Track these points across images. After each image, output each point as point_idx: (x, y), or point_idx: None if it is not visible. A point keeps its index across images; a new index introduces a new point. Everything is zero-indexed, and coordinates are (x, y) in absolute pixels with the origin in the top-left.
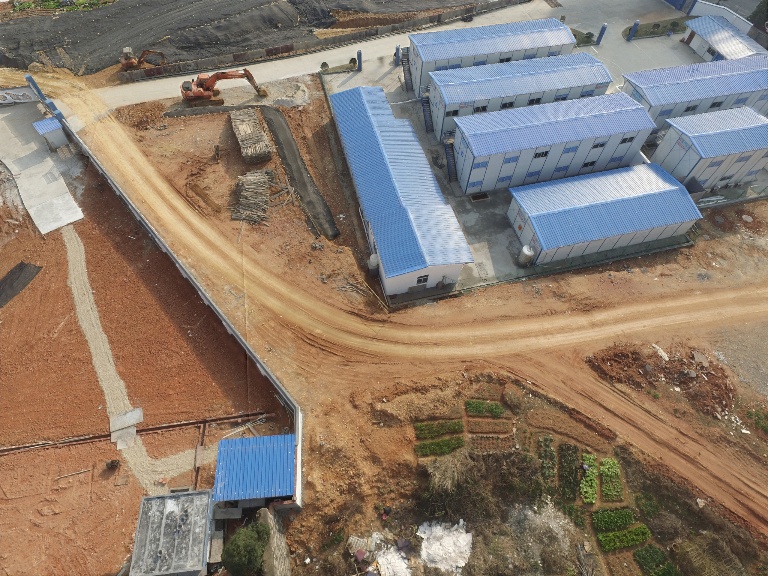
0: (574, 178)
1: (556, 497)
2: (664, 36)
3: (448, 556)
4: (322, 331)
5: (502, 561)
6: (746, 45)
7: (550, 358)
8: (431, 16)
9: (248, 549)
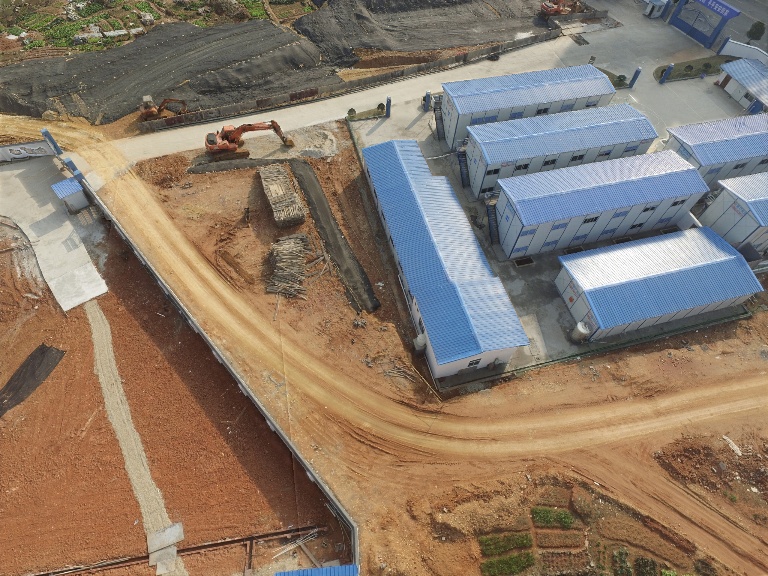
0: (625, 244)
1: None
2: (697, 78)
3: None
4: (371, 425)
5: None
6: None
7: (616, 454)
8: (457, 56)
9: None
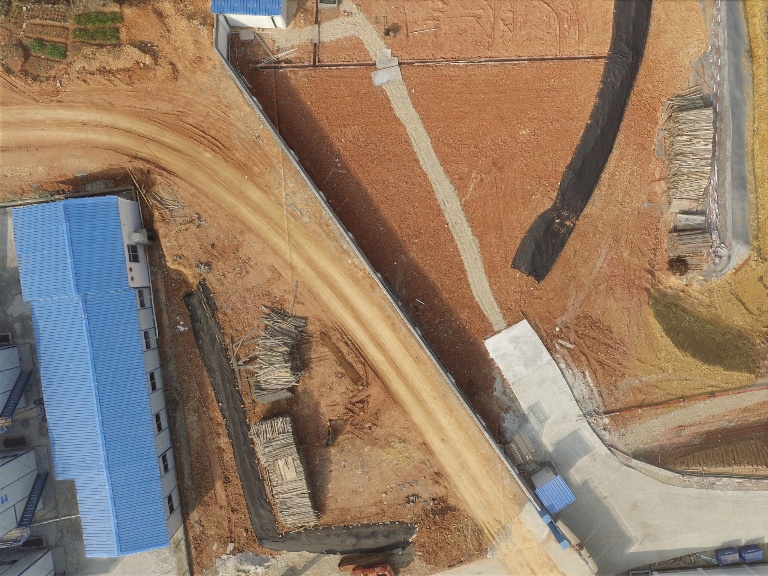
0: None
1: None
2: None
3: None
4: (203, 154)
5: None
6: None
7: None
8: None
9: None
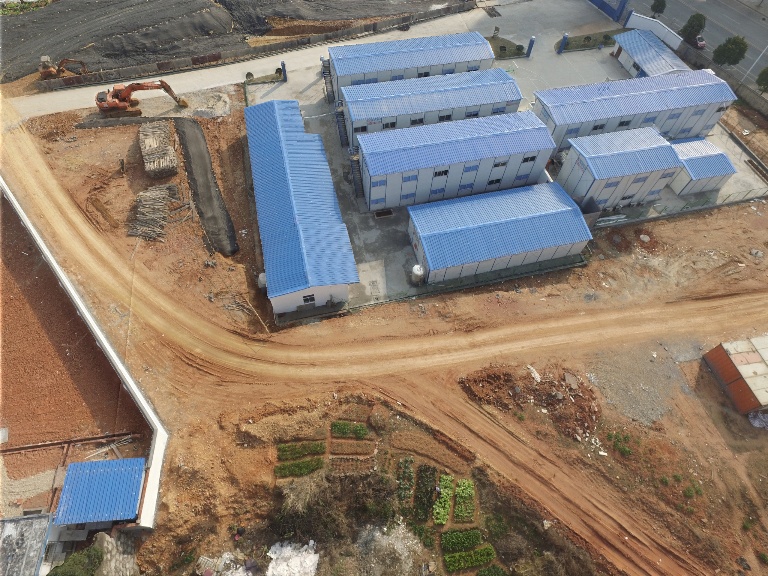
0: (473, 197)
1: (409, 518)
2: (595, 49)
3: None
4: (202, 350)
5: None
6: (668, 61)
7: (424, 379)
8: (366, 25)
9: (67, 575)
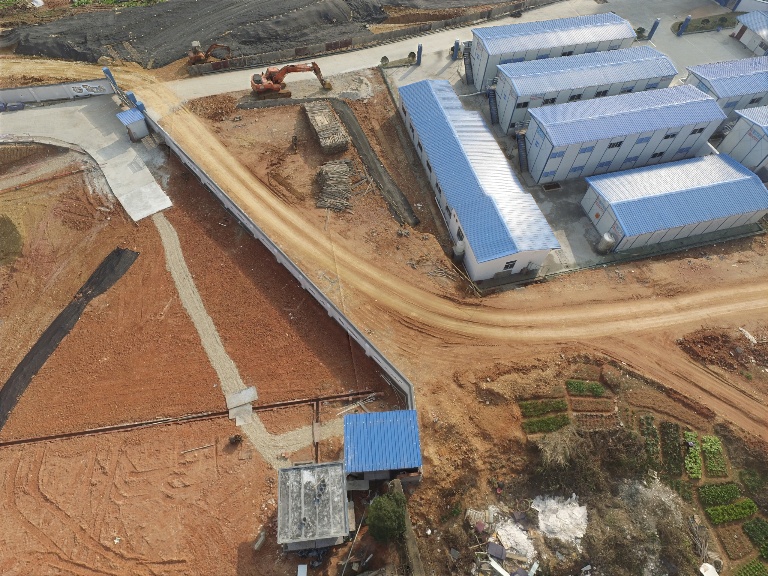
0: (647, 168)
1: (662, 473)
2: (713, 31)
3: (566, 527)
4: (418, 314)
5: (620, 532)
6: None
7: (642, 340)
8: (482, 12)
9: (397, 515)
